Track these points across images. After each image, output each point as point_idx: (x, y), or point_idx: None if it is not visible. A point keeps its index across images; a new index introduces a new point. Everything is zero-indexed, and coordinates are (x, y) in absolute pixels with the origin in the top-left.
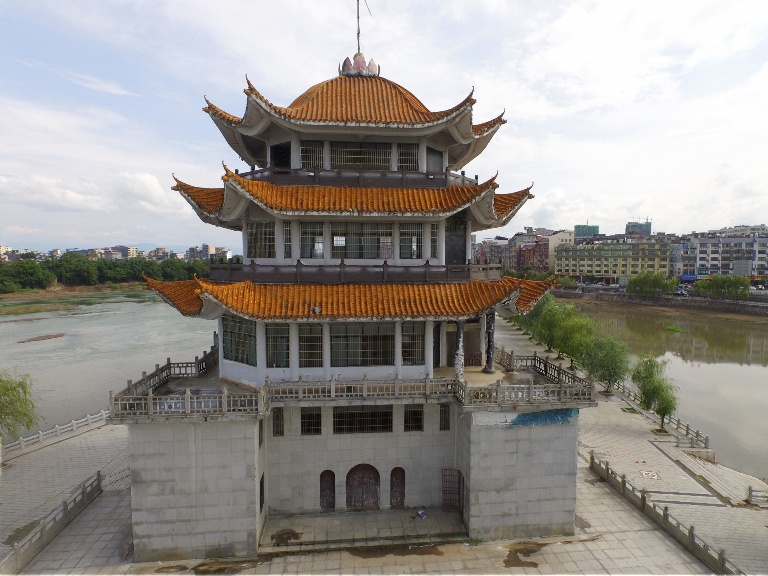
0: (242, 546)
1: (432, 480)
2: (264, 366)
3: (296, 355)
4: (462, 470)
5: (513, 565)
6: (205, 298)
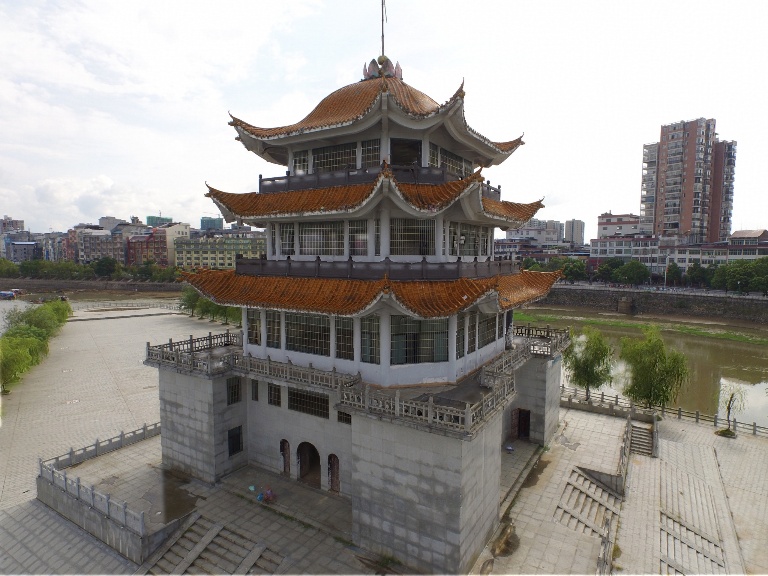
0: (495, 520)
1: (503, 423)
2: (455, 359)
3: (467, 344)
4: (527, 406)
5: (575, 448)
6: (491, 295)
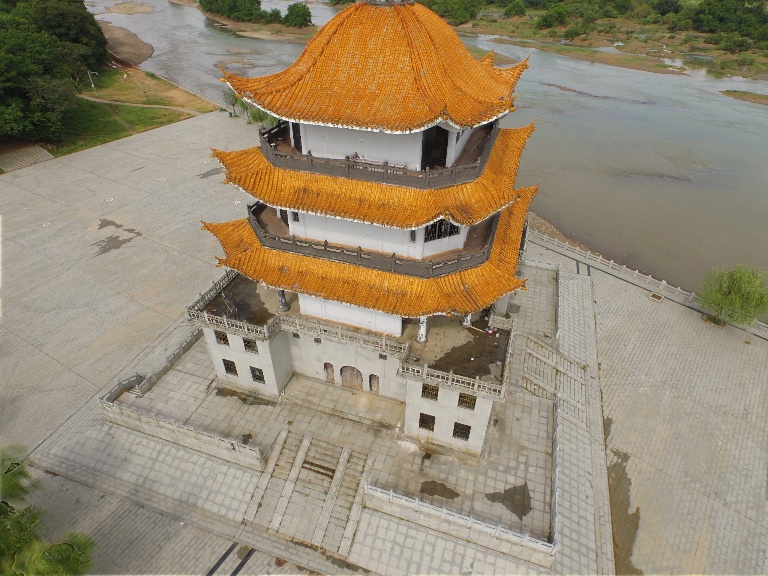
0: None
1: None
2: None
3: None
4: None
5: None
6: None
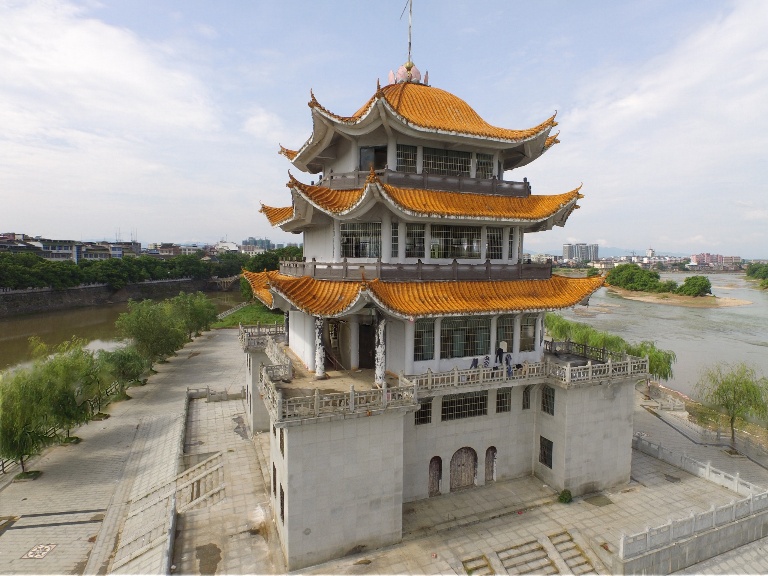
0: None
1: None
2: None
3: None
4: None
5: None
6: None
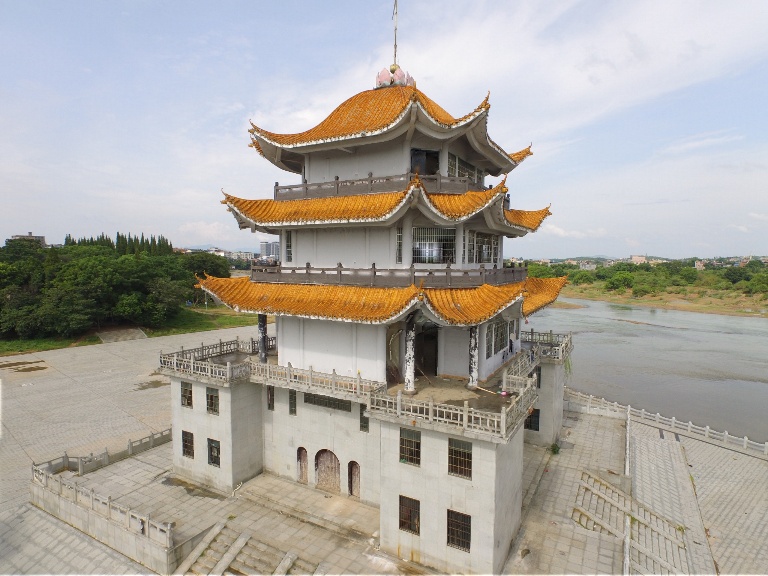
0: None
1: None
2: None
3: None
4: None
5: None
6: None
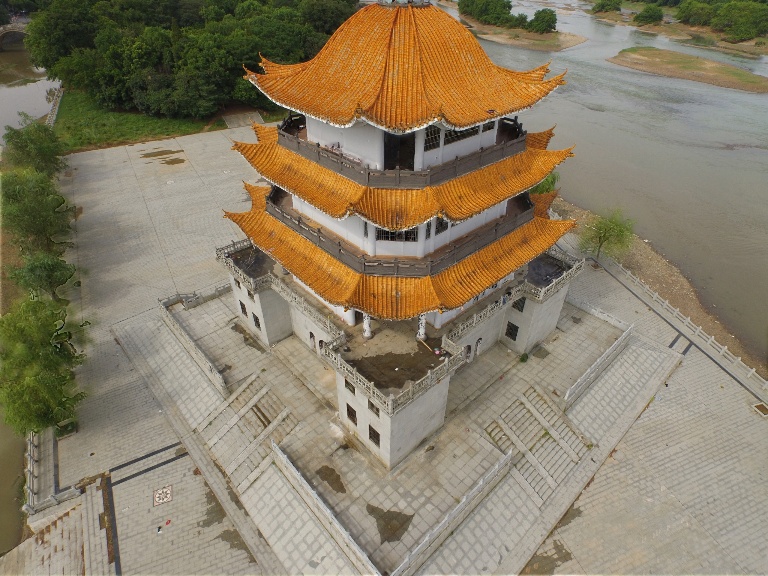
0: None
1: None
2: None
3: None
4: None
5: None
6: None
